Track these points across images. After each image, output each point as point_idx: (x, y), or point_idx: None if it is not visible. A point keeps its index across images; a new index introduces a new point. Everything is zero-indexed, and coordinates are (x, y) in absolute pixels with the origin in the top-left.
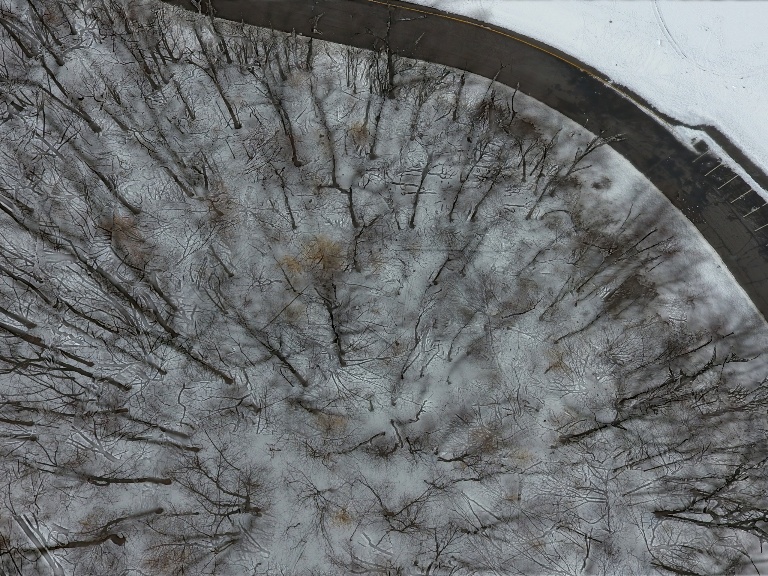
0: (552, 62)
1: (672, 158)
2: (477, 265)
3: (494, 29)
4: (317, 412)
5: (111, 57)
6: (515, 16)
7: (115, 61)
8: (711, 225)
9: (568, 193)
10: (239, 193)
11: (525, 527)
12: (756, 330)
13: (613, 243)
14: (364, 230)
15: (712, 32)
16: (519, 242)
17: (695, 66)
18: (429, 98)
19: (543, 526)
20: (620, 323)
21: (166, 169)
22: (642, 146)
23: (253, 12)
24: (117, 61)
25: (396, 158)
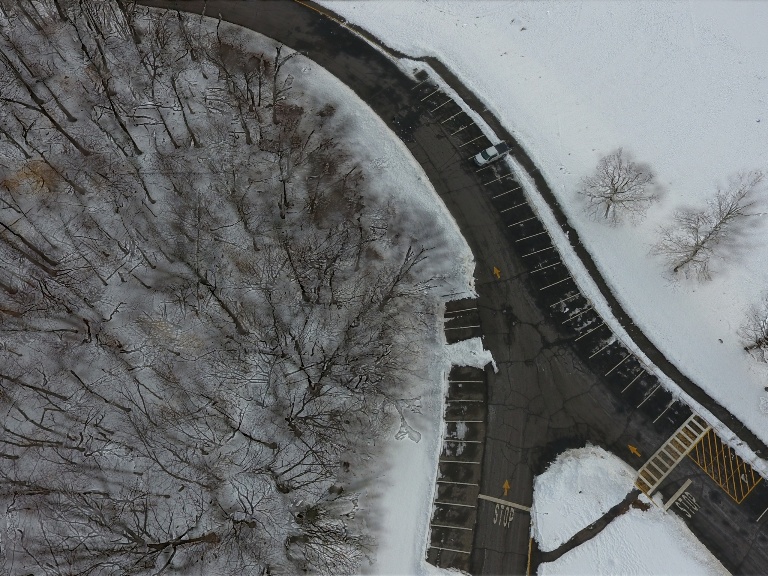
0: (295, 7)
1: (393, 87)
2: (195, 185)
3: None
4: (18, 315)
5: None
6: None
7: None
8: (420, 143)
9: (289, 119)
10: None
11: (183, 404)
12: (446, 233)
13: None
14: (93, 157)
15: None
16: (238, 164)
17: (433, 8)
18: (169, 40)
19: (200, 403)
20: (324, 232)
21: None
22: (367, 77)
23: None
24: None
25: (125, 92)
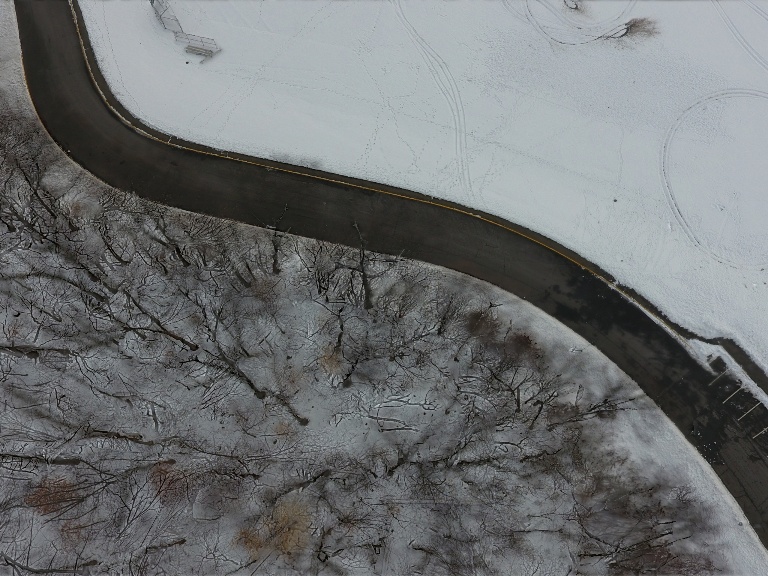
0: (550, 258)
1: (685, 380)
2: (464, 522)
3: (485, 217)
4: None
5: (53, 260)
6: (508, 199)
7: (57, 265)
8: (731, 467)
9: (568, 428)
10: (194, 434)
11: None
12: None
13: (621, 542)
14: None
15: (728, 212)
16: (512, 491)
17: (710, 257)
18: (411, 311)
19: None
20: None
21: (104, 434)
22: (651, 364)
23: (214, 200)
24: (59, 265)
25: None
